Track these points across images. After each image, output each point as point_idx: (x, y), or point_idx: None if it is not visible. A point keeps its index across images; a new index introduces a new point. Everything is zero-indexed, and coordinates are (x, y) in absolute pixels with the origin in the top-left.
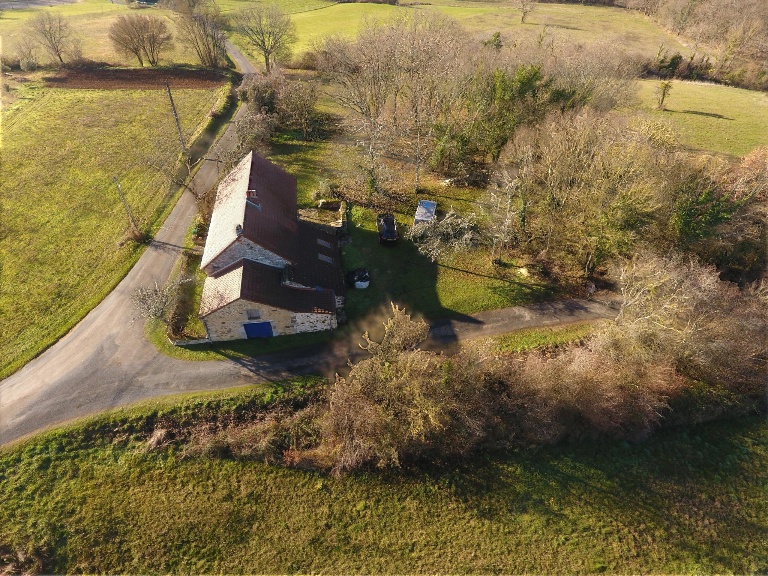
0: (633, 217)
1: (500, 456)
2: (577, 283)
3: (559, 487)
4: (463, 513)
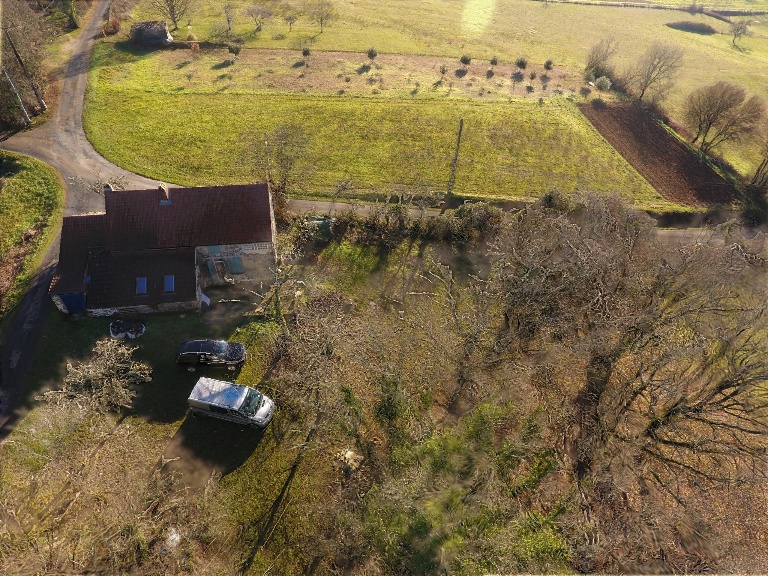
0: None
1: None
2: None
3: None
4: None
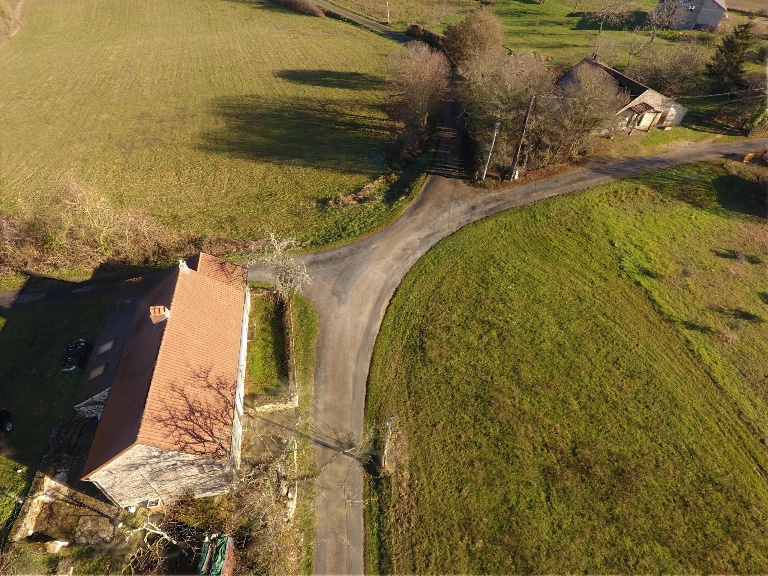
0: None
1: None
2: None
3: None
4: None
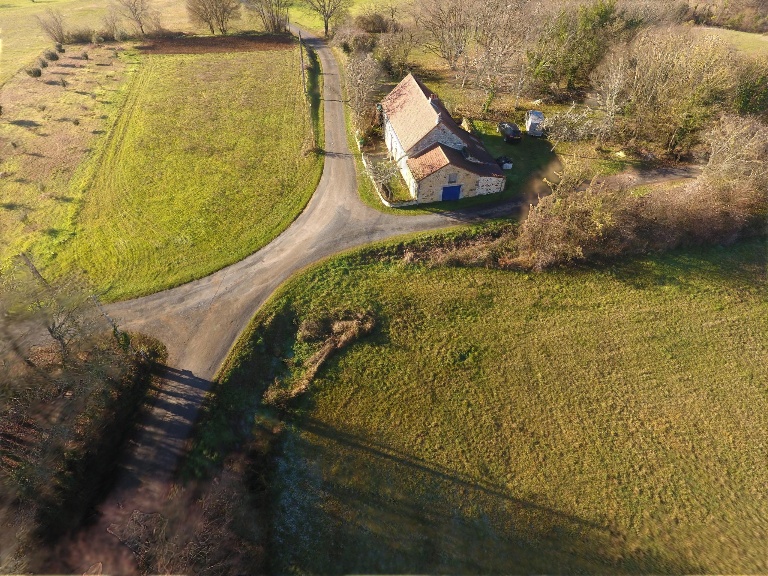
0: (712, 97)
1: (639, 257)
2: (662, 158)
3: (683, 271)
4: (625, 287)
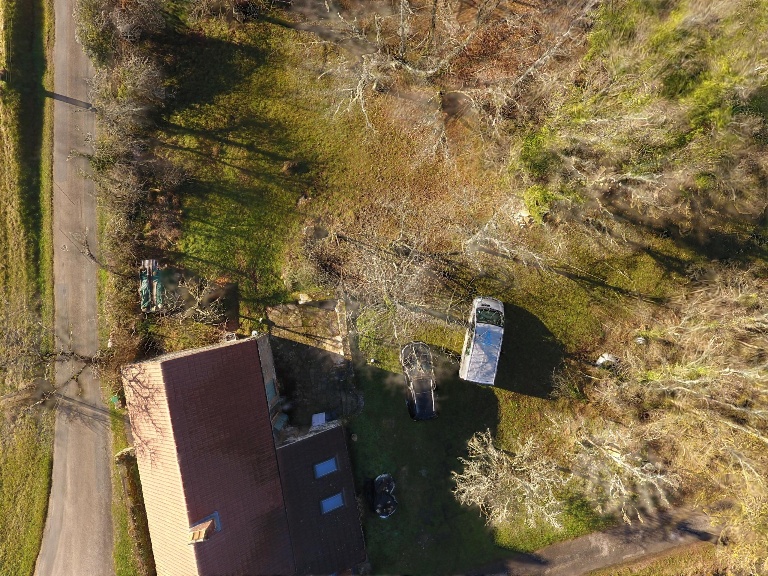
0: None
1: None
2: (688, 483)
3: None
4: None
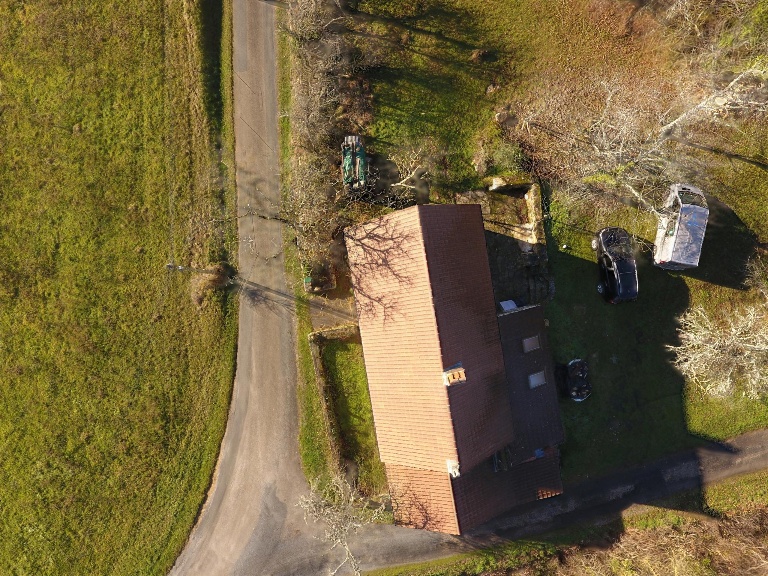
0: None
1: None
2: None
3: None
4: None
